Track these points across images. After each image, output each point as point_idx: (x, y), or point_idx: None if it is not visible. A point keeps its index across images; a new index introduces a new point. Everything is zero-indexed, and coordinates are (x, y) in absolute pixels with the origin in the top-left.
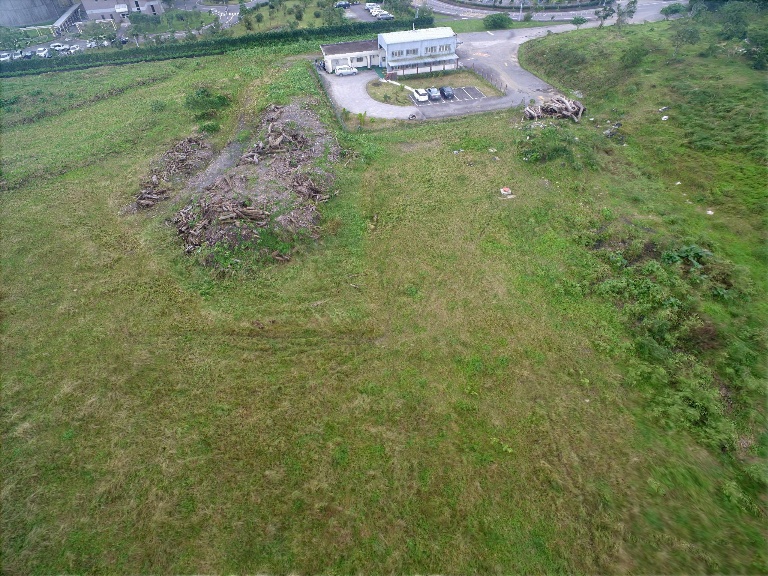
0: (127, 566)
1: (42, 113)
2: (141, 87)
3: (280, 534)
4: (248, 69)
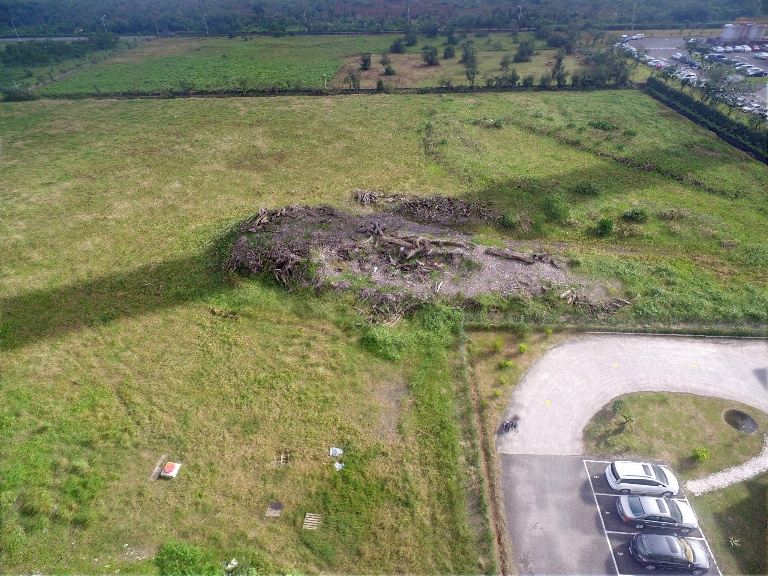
0: (74, 211)
1: (576, 142)
2: (669, 179)
3: (30, 244)
4: (766, 249)
